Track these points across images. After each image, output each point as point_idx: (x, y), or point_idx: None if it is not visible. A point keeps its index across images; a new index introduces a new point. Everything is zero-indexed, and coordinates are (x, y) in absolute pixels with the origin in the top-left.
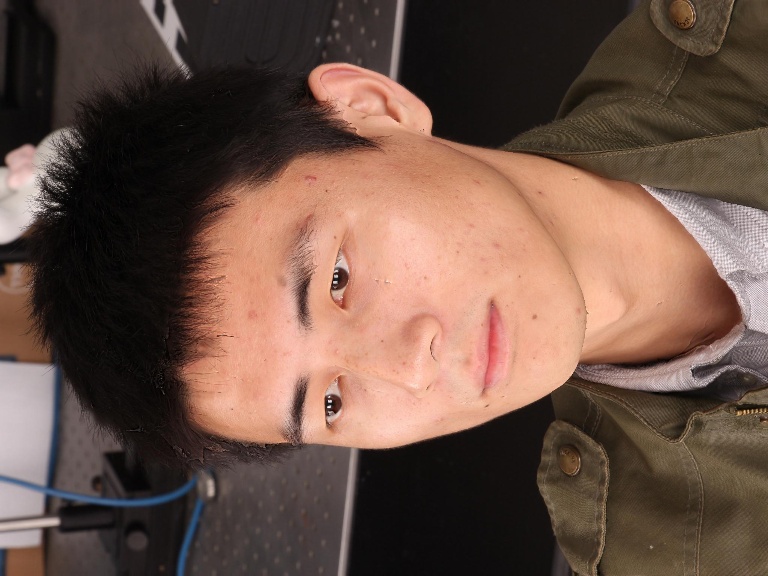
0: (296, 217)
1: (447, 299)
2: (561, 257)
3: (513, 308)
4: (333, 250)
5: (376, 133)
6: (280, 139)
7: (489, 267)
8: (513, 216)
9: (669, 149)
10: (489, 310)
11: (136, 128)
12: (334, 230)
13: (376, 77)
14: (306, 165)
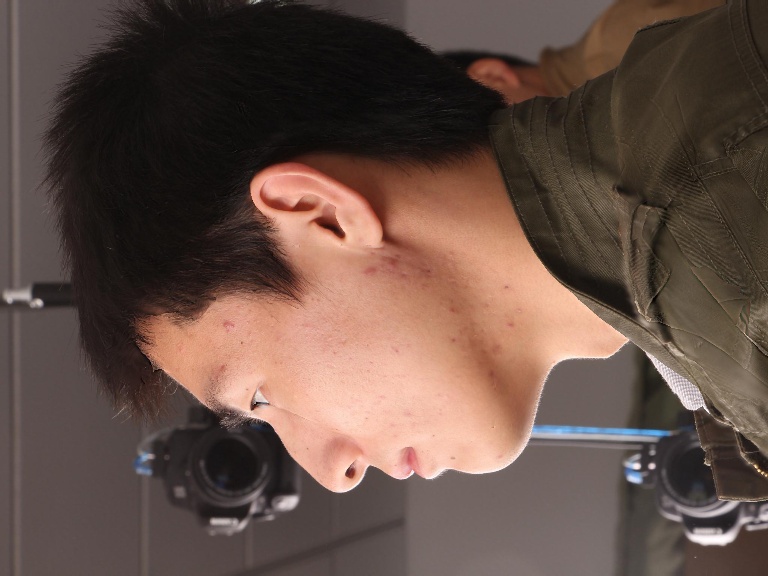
0: (212, 362)
1: (362, 440)
2: (485, 412)
3: (429, 454)
4: (246, 398)
5: (311, 260)
6: (200, 283)
7: (399, 432)
8: (431, 383)
9: (622, 319)
10: (405, 451)
11: (86, 203)
12: (245, 385)
13: (323, 186)
14: (228, 306)
